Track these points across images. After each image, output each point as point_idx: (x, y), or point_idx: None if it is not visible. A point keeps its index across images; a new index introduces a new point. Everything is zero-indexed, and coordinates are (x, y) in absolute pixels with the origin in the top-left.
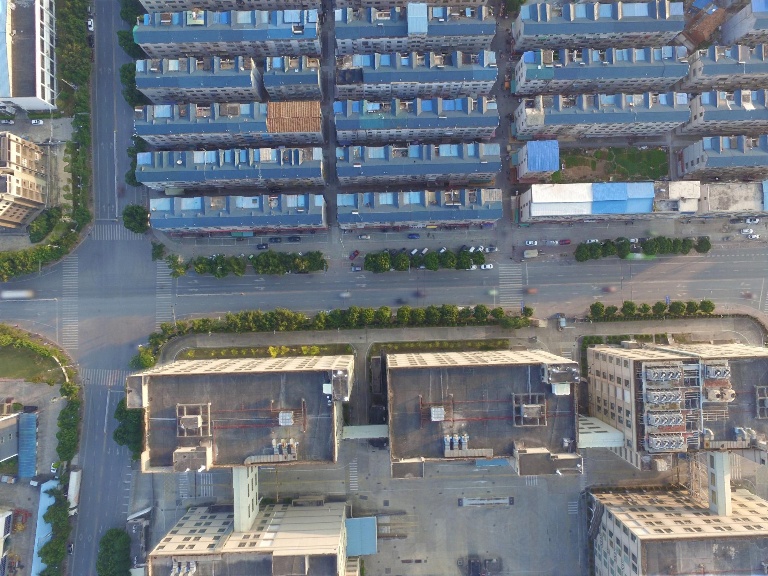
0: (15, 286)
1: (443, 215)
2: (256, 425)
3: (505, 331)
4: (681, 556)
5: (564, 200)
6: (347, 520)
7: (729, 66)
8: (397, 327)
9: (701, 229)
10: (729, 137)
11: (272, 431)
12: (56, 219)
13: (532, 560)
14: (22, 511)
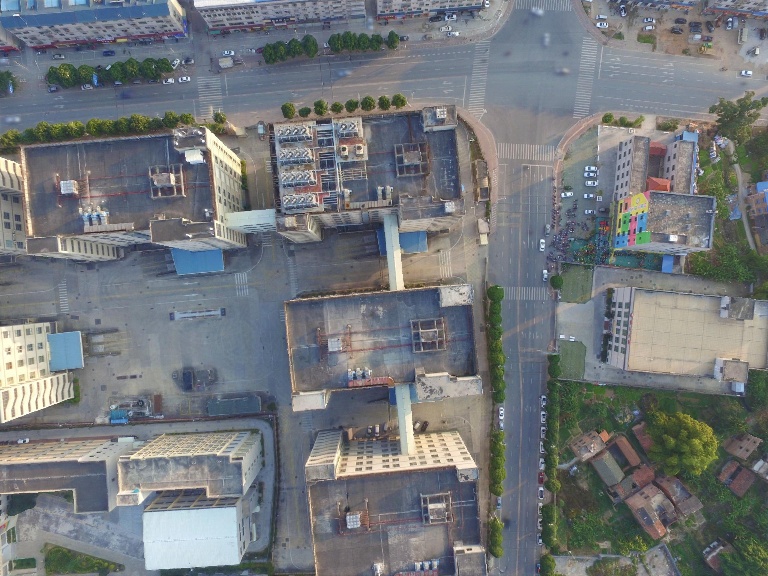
0: None
1: (108, 14)
2: None
3: None
4: (329, 318)
5: None
6: (50, 335)
7: None
8: None
9: (400, 30)
10: None
11: None
12: None
13: (247, 369)
14: None
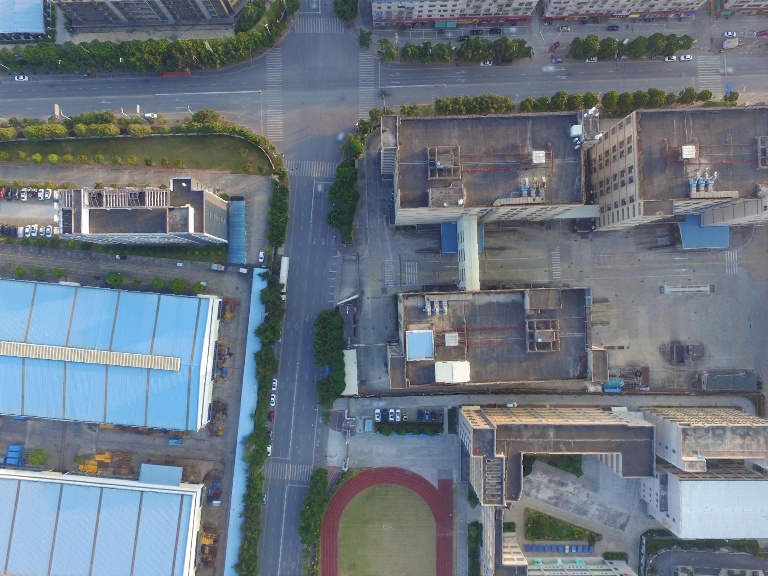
0: (220, 79)
1: None
2: (504, 169)
3: None
4: None
5: None
6: None
7: None
8: None
9: None
10: None
11: (521, 173)
12: (262, 10)
13: (733, 346)
14: (231, 299)
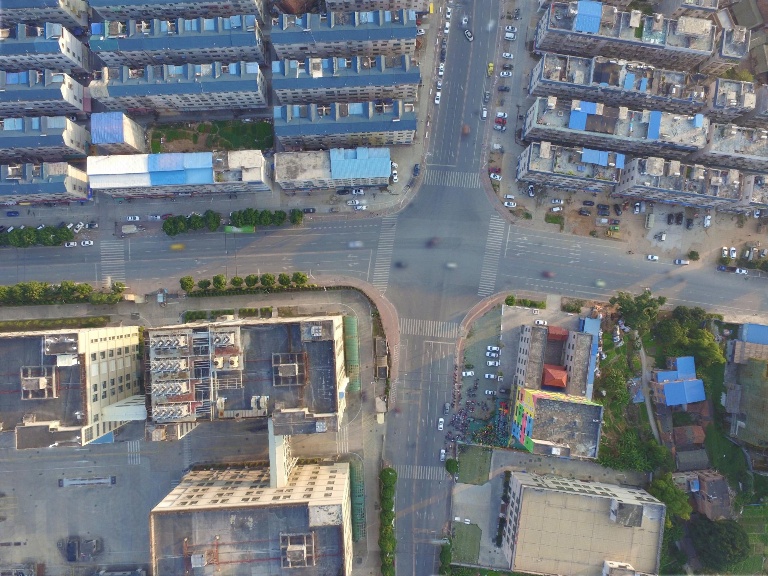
0: None
1: (4, 190)
2: None
3: (107, 308)
4: (197, 528)
5: (119, 171)
6: None
7: (297, 34)
8: None
9: (308, 201)
10: (299, 106)
11: None
12: None
13: (134, 540)
14: None
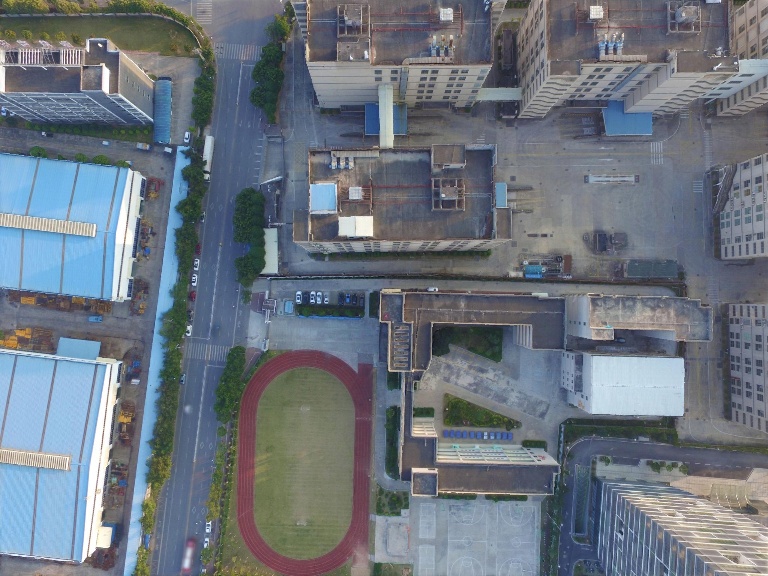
0: None
1: None
2: (414, 29)
3: None
4: None
5: None
6: None
7: None
8: (526, 7)
9: None
10: None
11: (430, 33)
12: None
13: (657, 237)
14: (155, 179)
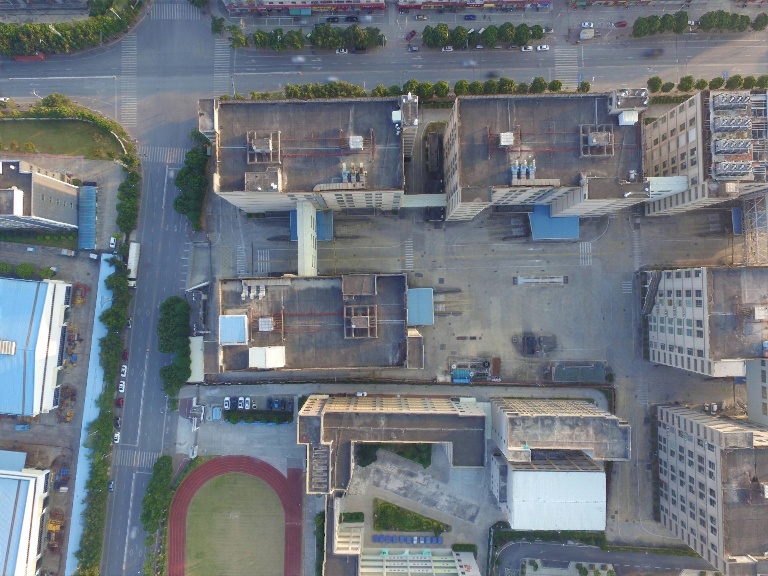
0: (74, 64)
1: None
2: (325, 154)
3: None
4: (746, 287)
5: None
6: None
7: None
8: None
9: (757, 13)
10: None
11: (341, 159)
12: None
13: (586, 338)
14: (81, 285)
